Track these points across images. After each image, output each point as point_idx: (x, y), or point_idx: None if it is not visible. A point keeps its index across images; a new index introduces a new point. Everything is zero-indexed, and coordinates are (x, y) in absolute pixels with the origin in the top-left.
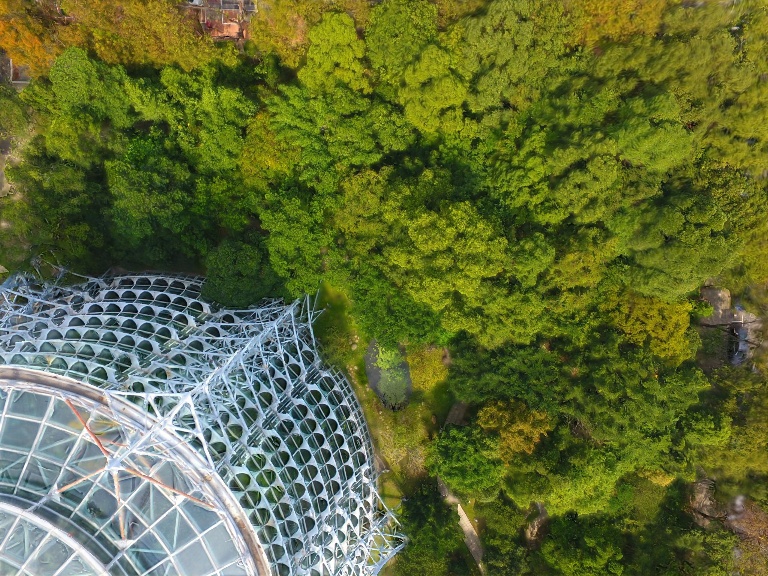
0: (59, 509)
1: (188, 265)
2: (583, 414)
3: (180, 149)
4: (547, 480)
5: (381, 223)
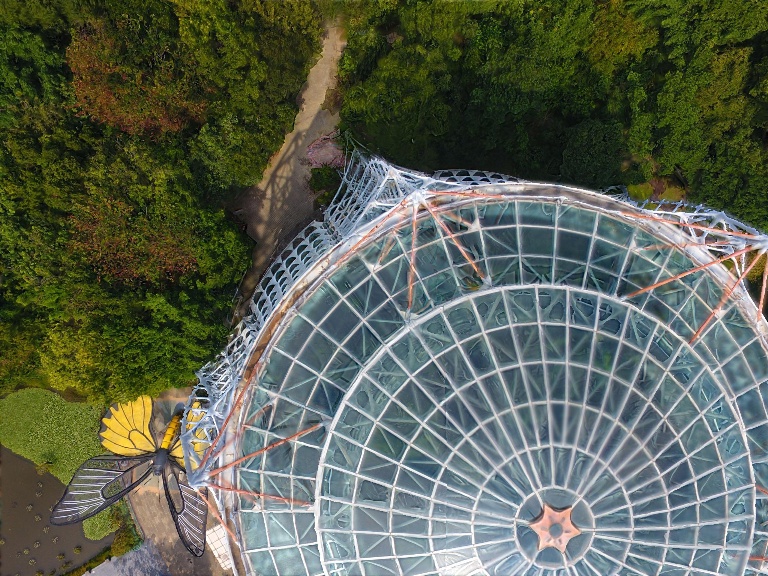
0: None
1: (501, 161)
2: None
3: (527, 35)
4: None
5: (738, 105)
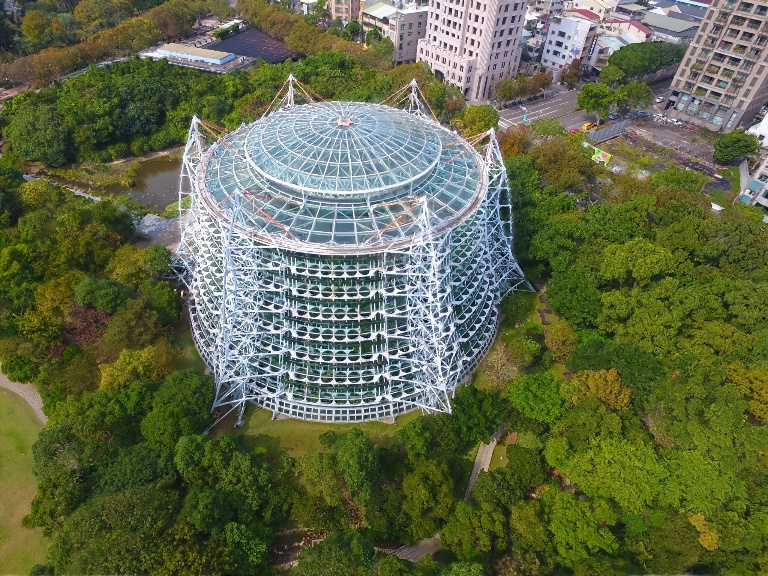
0: None
1: None
2: (663, 401)
3: (530, 200)
4: (601, 417)
5: None
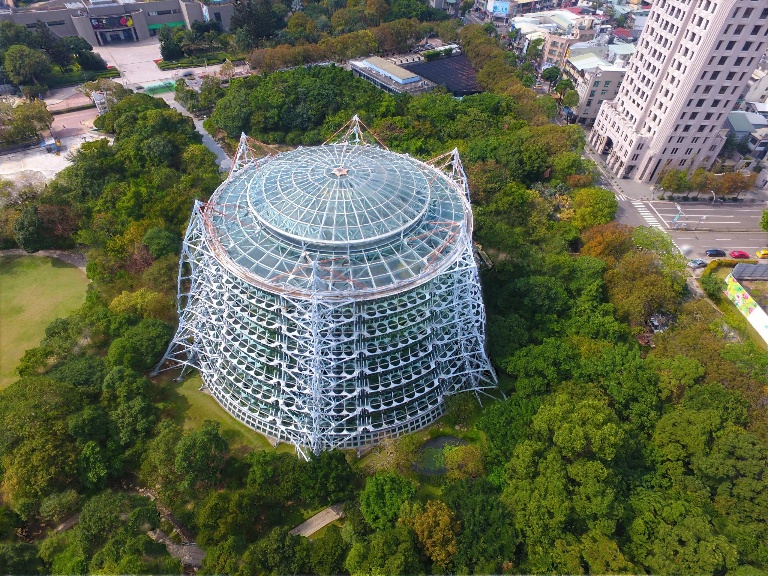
0: (419, 223)
1: None
2: None
3: None
4: (394, 552)
5: None
